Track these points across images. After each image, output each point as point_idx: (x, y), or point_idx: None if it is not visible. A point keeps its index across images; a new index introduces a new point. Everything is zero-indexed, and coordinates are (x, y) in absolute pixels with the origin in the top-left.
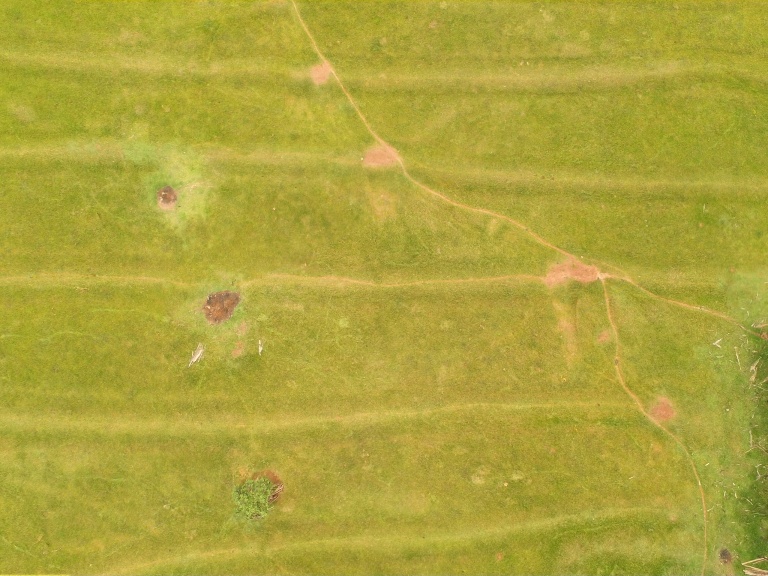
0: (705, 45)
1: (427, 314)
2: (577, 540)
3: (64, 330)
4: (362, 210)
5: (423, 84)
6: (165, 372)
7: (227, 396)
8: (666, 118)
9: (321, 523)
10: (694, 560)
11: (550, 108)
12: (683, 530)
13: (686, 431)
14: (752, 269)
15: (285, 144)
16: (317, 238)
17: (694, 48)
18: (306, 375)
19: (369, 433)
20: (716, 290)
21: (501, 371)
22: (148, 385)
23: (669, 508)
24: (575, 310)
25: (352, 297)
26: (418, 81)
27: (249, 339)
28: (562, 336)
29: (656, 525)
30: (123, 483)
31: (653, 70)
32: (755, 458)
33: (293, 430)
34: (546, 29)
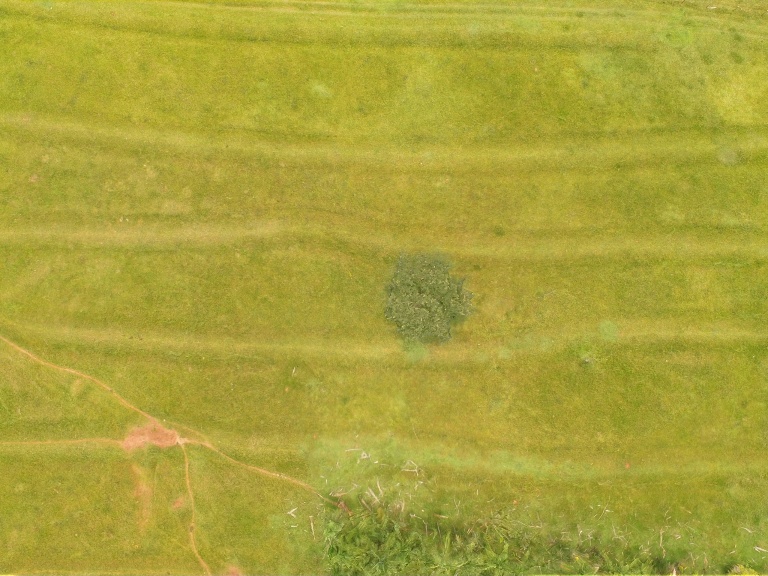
0: (307, 205)
1: (2, 476)
2: None
3: None
4: None
5: (19, 239)
6: None
7: None
8: (262, 278)
9: None
10: None
11: (146, 266)
12: None
13: None
14: (335, 436)
15: None
16: None
17: (297, 207)
18: None
19: None
20: (297, 457)
21: (73, 536)
22: None
23: None
24: (154, 474)
25: None
26: (13, 236)
27: None
28: (138, 501)
29: None
30: None
31: (251, 230)
32: None
33: None
34: (147, 185)
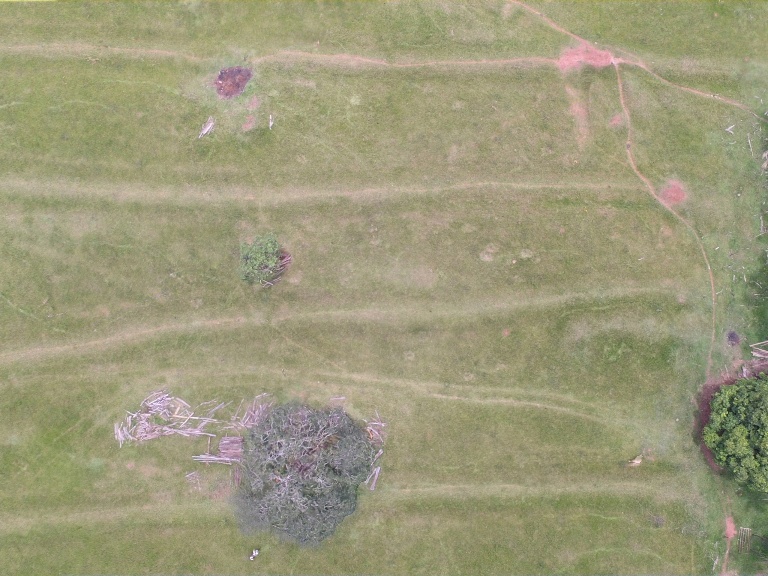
0: None
1: (439, 94)
2: (585, 318)
3: (75, 99)
4: None
5: None
6: (175, 143)
7: (236, 169)
8: None
9: (328, 296)
10: (702, 341)
11: None
12: (691, 311)
13: (697, 214)
14: (766, 59)
15: None
16: (331, 17)
17: None
18: (316, 150)
19: (378, 210)
20: (730, 79)
21: (512, 152)
22: (157, 155)
23: (678, 289)
24: (588, 95)
25: (364, 76)
26: None
27: (260, 113)
28: (574, 119)
29: (664, 306)
30: (130, 249)
31: None
32: (765, 243)
33: (302, 204)
34: None
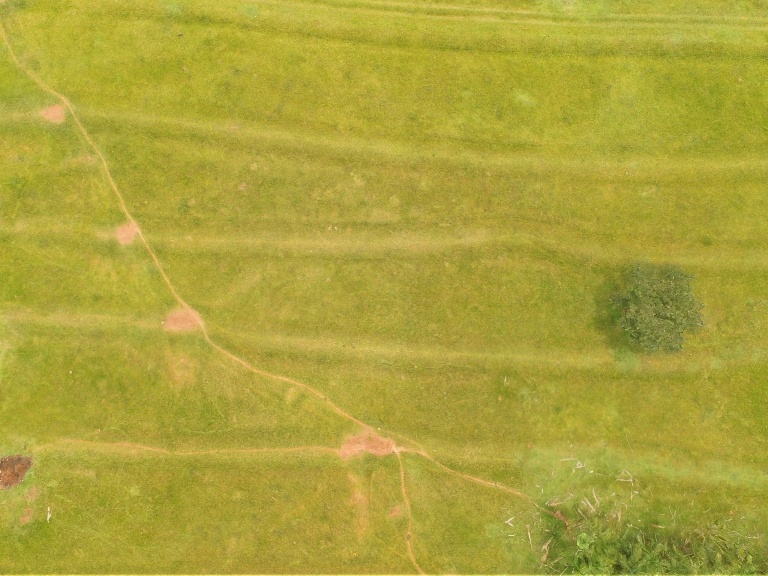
0: (515, 214)
1: (220, 484)
2: None
3: None
4: (160, 375)
5: (229, 247)
6: None
7: (13, 563)
8: (472, 287)
9: None
10: None
11: (356, 274)
12: None
13: None
14: (549, 445)
15: (86, 305)
16: (113, 403)
17: (504, 216)
18: (94, 544)
19: None
20: (512, 466)
21: (291, 544)
22: None
23: None
24: (369, 483)
25: (145, 464)
26: (224, 244)
27: (38, 506)
28: (355, 509)
29: None
30: None
31: (460, 239)
32: None
33: None
34: (356, 194)
